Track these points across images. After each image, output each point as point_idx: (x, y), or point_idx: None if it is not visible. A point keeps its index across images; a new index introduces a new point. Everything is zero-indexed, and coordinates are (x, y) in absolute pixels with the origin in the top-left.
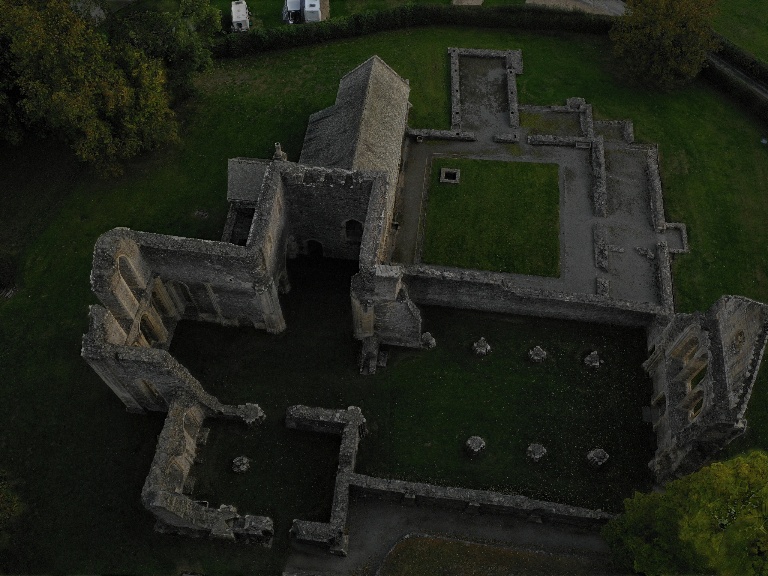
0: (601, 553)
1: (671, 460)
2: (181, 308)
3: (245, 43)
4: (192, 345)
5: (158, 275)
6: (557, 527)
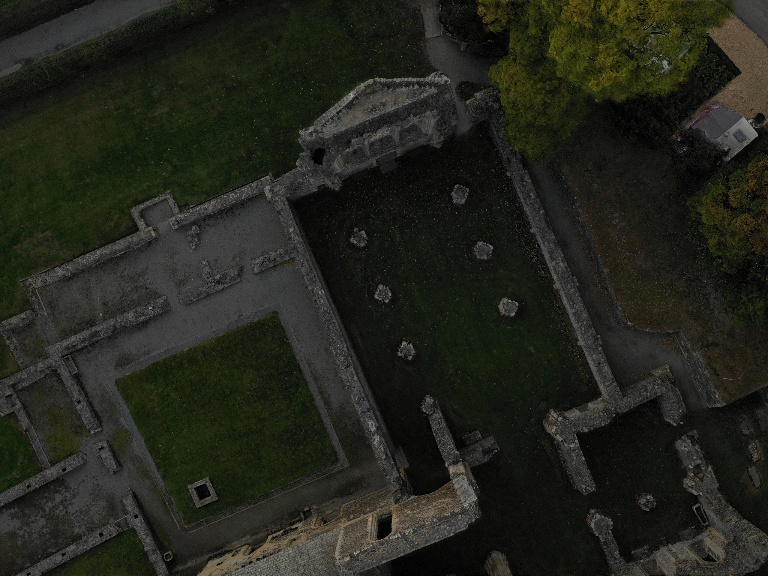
0: None
1: None
2: None
3: None
4: None
5: None
6: (543, 203)
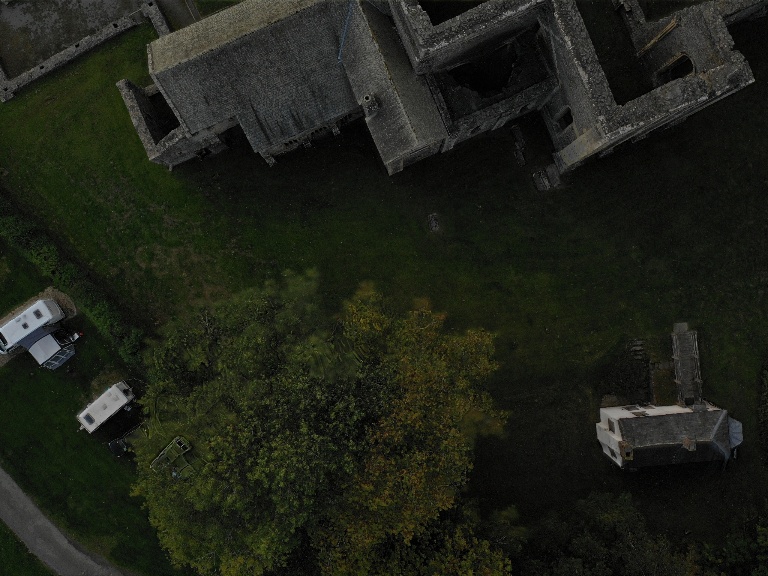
0: None
1: None
2: None
3: None
4: None
5: None
6: None
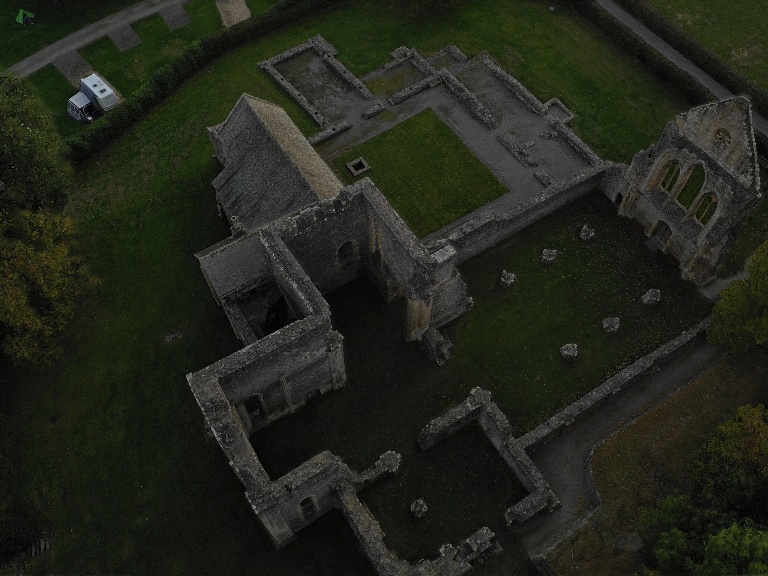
0: (710, 359)
1: (706, 260)
2: (249, 424)
3: (67, 160)
4: (281, 449)
5: (232, 402)
6: (671, 365)
